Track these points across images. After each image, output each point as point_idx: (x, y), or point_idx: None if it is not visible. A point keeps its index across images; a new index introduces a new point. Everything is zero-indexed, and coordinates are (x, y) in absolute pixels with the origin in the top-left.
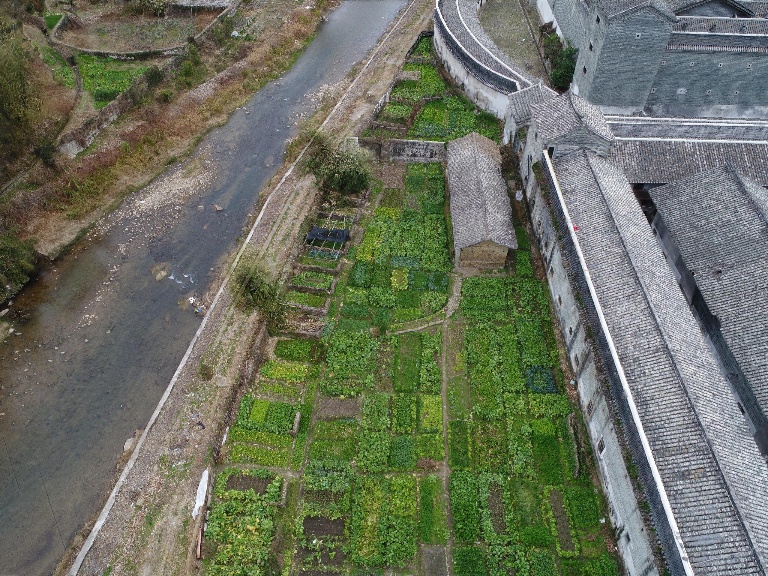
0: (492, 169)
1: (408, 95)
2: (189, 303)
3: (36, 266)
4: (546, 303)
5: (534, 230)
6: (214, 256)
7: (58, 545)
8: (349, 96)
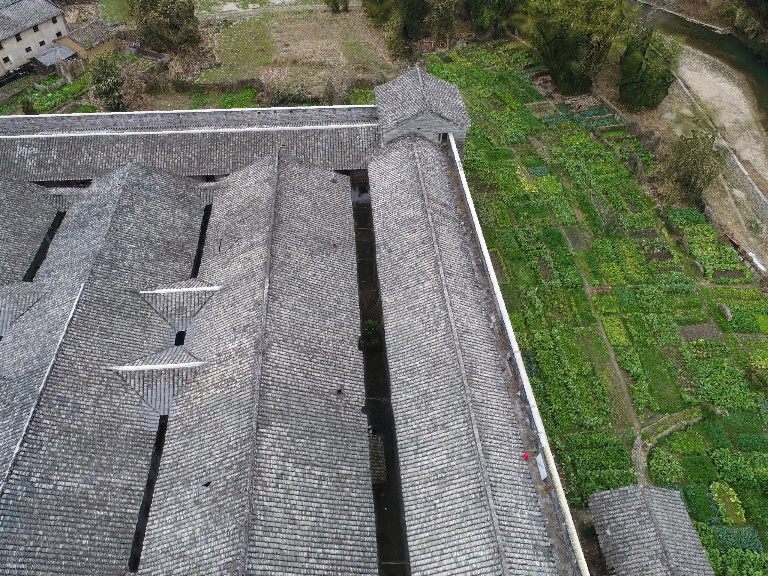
0: None
1: None
2: None
3: None
4: None
5: None
6: None
7: None
8: None
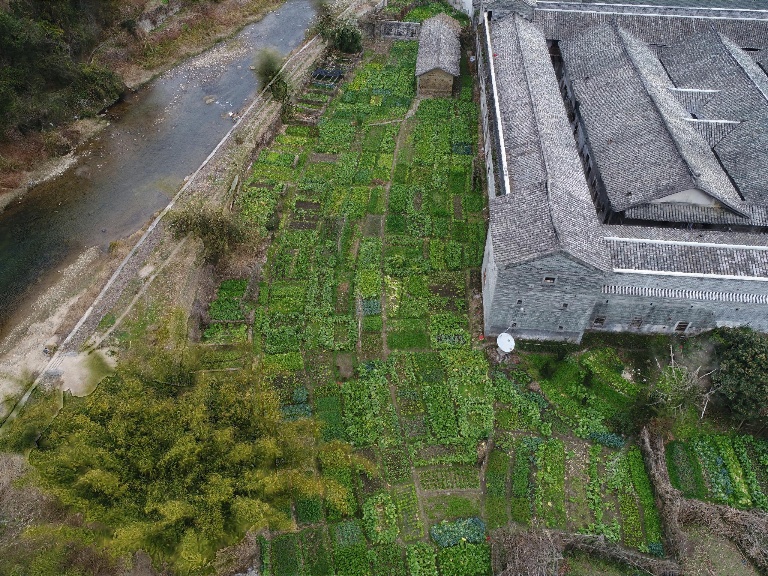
0: (451, 34)
1: (403, 2)
2: (229, 115)
3: (123, 93)
4: (476, 113)
5: (478, 76)
6: (247, 93)
7: (144, 219)
8: (357, 3)
